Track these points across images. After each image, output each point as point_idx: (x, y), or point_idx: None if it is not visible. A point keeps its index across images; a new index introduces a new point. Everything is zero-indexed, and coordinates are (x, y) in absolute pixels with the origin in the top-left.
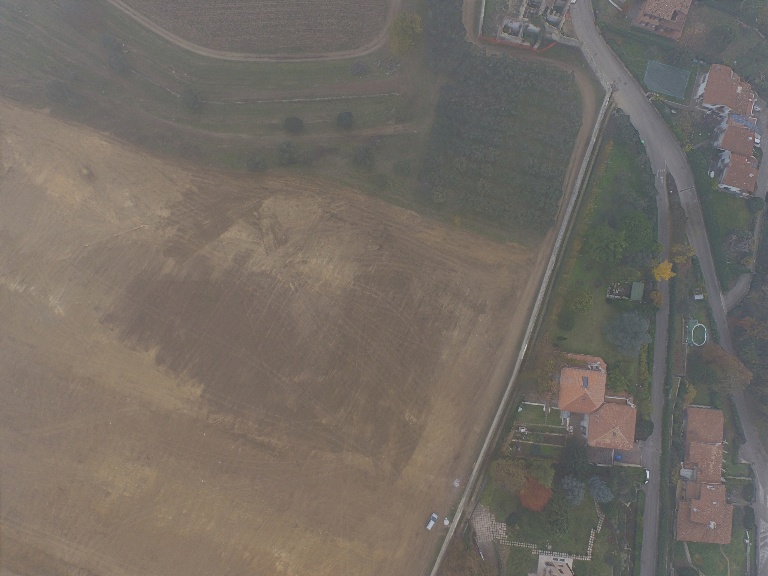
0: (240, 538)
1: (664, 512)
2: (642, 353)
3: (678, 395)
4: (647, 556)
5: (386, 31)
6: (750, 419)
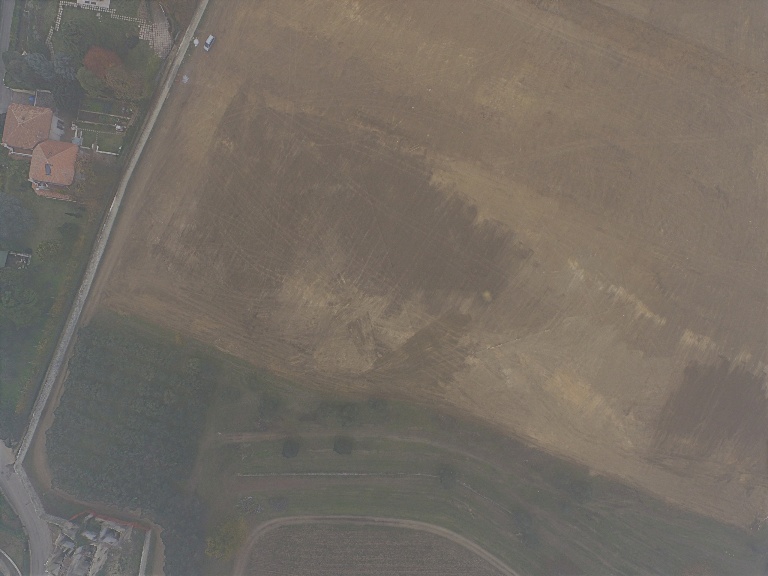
0: (393, 34)
1: None
2: None
3: None
4: (12, 5)
5: (251, 543)
6: None
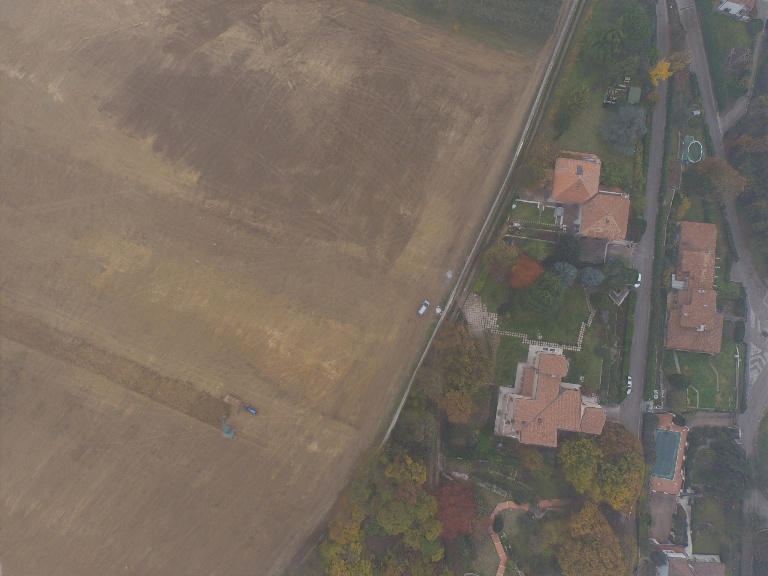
0: (233, 316)
1: (655, 313)
2: (637, 155)
3: (672, 206)
4: (637, 358)
5: None
6: (743, 244)
